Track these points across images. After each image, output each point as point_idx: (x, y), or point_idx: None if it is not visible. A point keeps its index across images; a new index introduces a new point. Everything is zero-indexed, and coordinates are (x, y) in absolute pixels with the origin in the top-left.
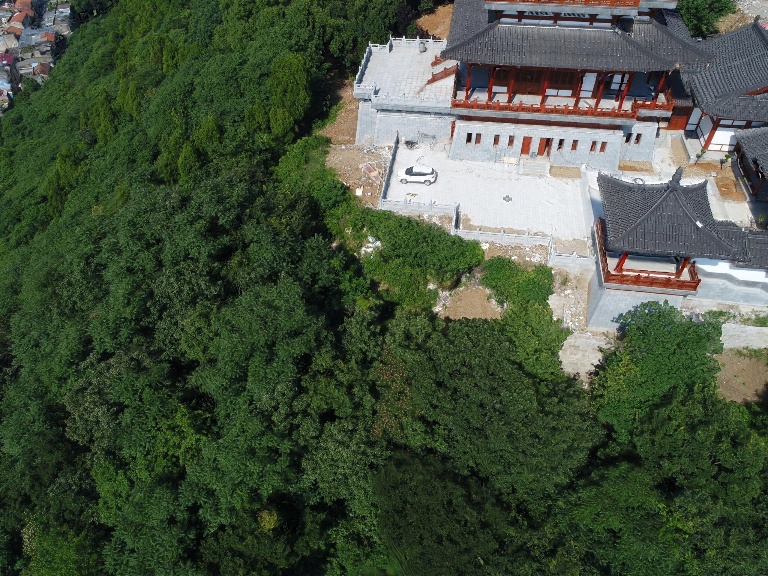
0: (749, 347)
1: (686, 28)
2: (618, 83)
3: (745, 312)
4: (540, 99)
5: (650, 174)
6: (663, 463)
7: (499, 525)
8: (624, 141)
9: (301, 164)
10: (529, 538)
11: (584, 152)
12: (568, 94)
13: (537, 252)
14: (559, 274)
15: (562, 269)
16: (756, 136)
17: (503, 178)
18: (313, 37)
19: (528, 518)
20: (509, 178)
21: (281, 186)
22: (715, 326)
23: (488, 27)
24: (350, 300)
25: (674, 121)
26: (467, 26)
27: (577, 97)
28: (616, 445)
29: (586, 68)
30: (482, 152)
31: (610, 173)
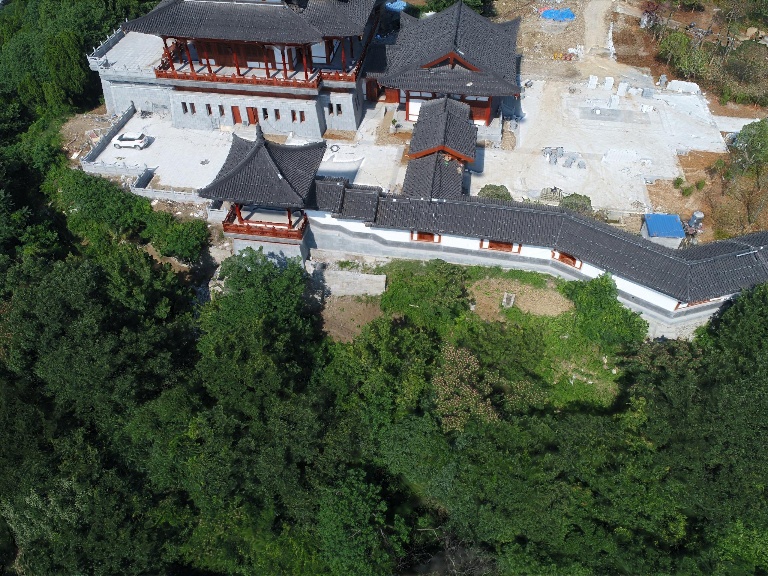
0: (368, 294)
1: (372, 5)
2: (317, 57)
3: (369, 262)
4: (243, 71)
5: (349, 142)
6: (204, 384)
7: (47, 435)
8: (327, 111)
9: (38, 131)
10: (63, 445)
11: (287, 121)
12: (269, 66)
13: (201, 208)
14: (216, 228)
15: (220, 224)
16: (433, 106)
17: (212, 144)
18: (110, 17)
19: (94, 433)
20: (217, 144)
21: (4, 150)
22: (292, 268)
23: (173, 2)
24: (19, 249)
25: (388, 94)
26: (169, 2)
27: (266, 68)
28: (196, 373)
29: (250, 40)
30: (200, 121)
31: (313, 141)
